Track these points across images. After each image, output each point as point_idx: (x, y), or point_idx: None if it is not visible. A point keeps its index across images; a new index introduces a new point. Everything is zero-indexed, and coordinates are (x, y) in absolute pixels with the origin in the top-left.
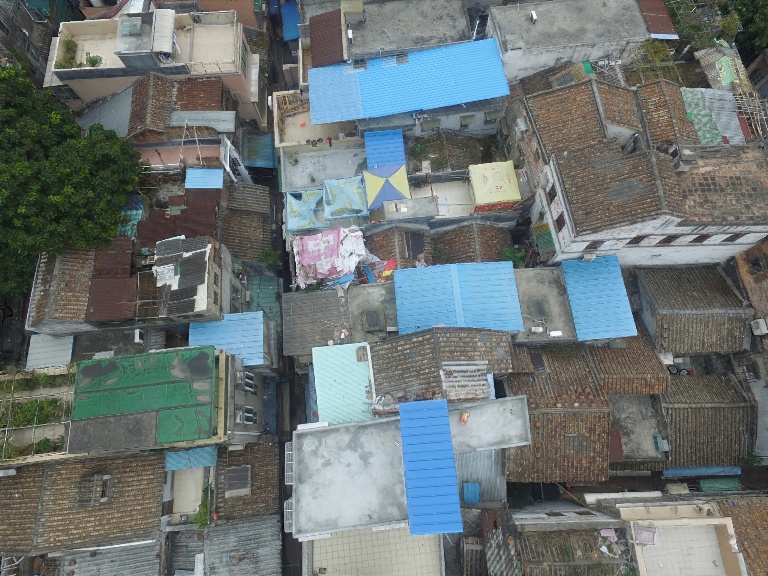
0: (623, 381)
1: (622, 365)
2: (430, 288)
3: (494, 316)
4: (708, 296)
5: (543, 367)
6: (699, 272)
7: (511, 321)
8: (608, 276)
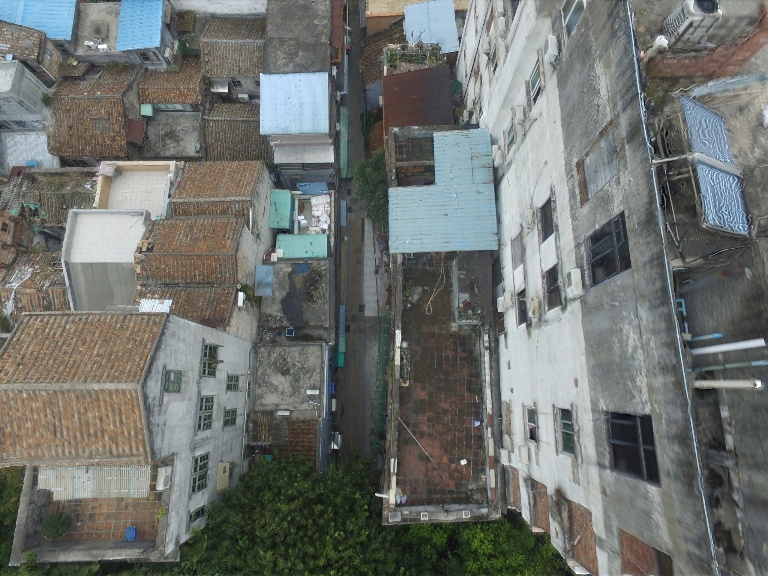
0: (163, 91)
1: (168, 81)
2: (2, 6)
3: (48, 28)
4: (251, 33)
5: (94, 75)
6: (261, 21)
7: (61, 32)
8: (152, 4)
